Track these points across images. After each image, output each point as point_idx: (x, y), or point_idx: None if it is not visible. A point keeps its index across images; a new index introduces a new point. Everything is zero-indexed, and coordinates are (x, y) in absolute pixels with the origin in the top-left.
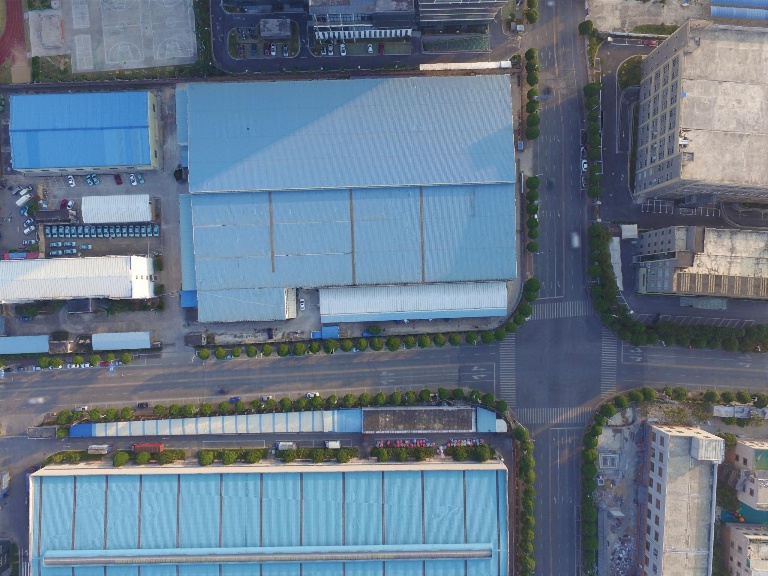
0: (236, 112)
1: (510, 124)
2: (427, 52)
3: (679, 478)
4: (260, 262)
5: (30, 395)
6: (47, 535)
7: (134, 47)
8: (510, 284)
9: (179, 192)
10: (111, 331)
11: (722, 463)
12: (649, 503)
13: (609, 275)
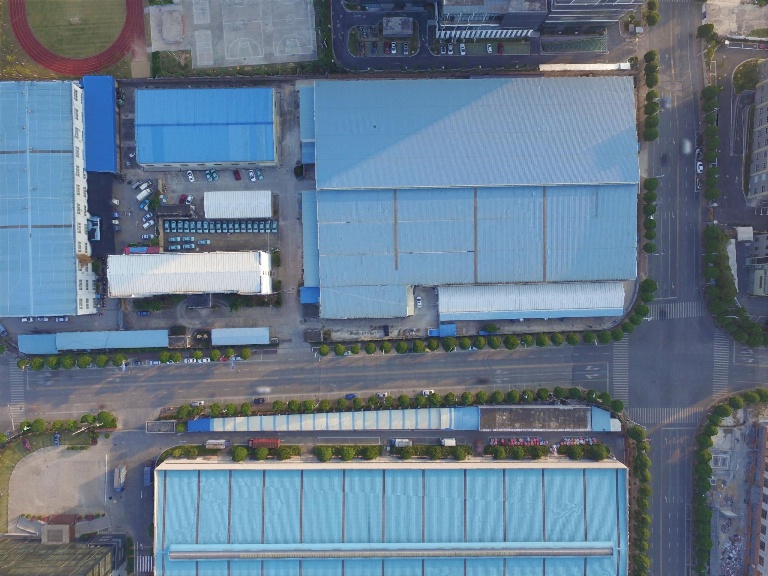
0: (362, 110)
1: (634, 125)
2: (545, 53)
3: None
4: (383, 259)
5: (146, 389)
6: (171, 529)
7: (254, 43)
8: (624, 284)
9: (297, 189)
10: (228, 326)
11: None
12: (764, 503)
13: (729, 277)
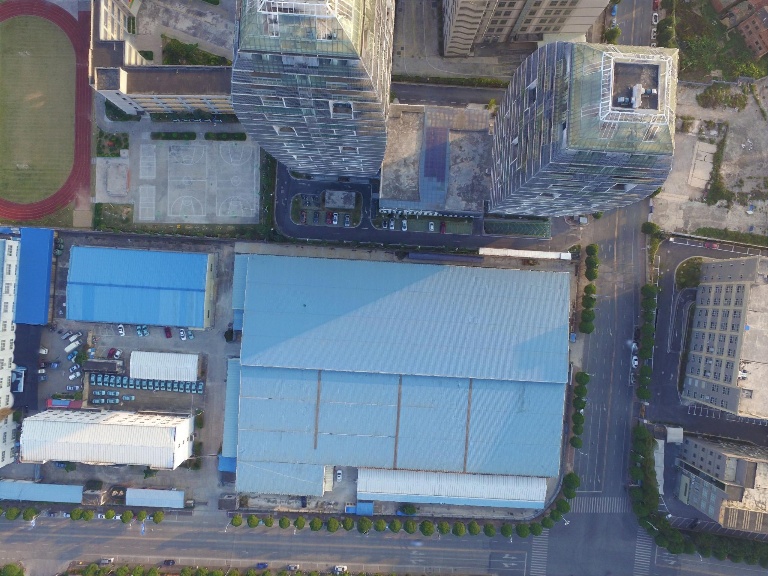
0: (294, 287)
1: (566, 324)
2: (488, 234)
3: None
4: (303, 438)
5: (58, 541)
6: None
7: (197, 202)
8: None
9: (227, 350)
10: (145, 484)
11: None
12: None
13: (652, 484)
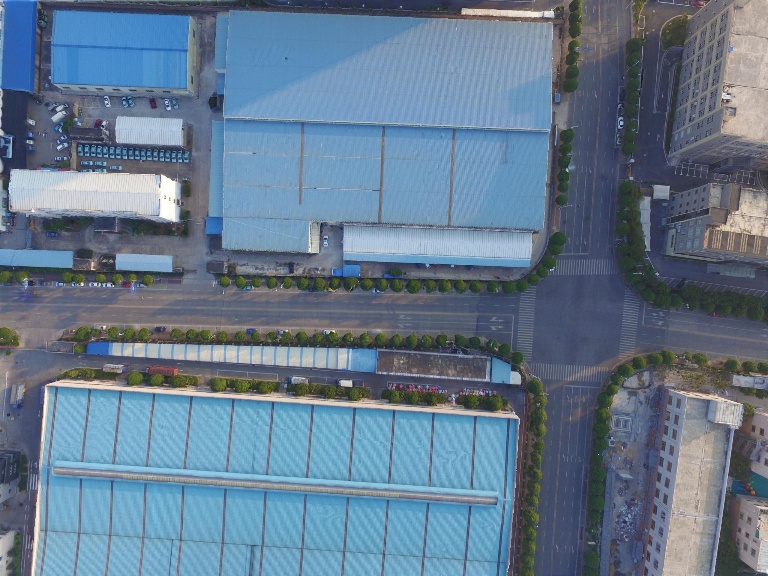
0: (275, 41)
1: (549, 72)
2: None
3: (693, 441)
4: (288, 193)
5: (51, 310)
6: (58, 445)
7: None
8: (535, 237)
9: None
10: (135, 253)
11: (737, 434)
12: (660, 467)
13: (638, 232)
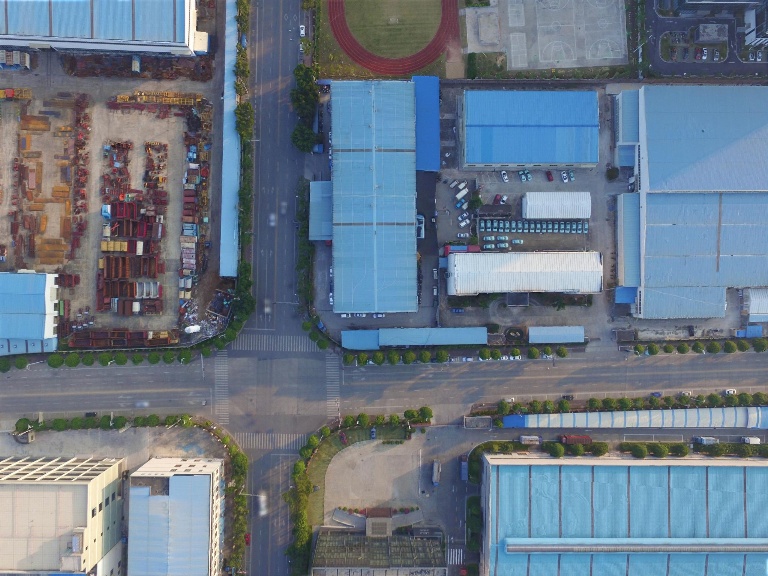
0: (690, 114)
1: None
2: None
3: None
4: (706, 261)
5: (458, 385)
6: (504, 523)
7: (567, 47)
8: None
9: (607, 190)
10: (538, 325)
11: None
12: None
13: None
